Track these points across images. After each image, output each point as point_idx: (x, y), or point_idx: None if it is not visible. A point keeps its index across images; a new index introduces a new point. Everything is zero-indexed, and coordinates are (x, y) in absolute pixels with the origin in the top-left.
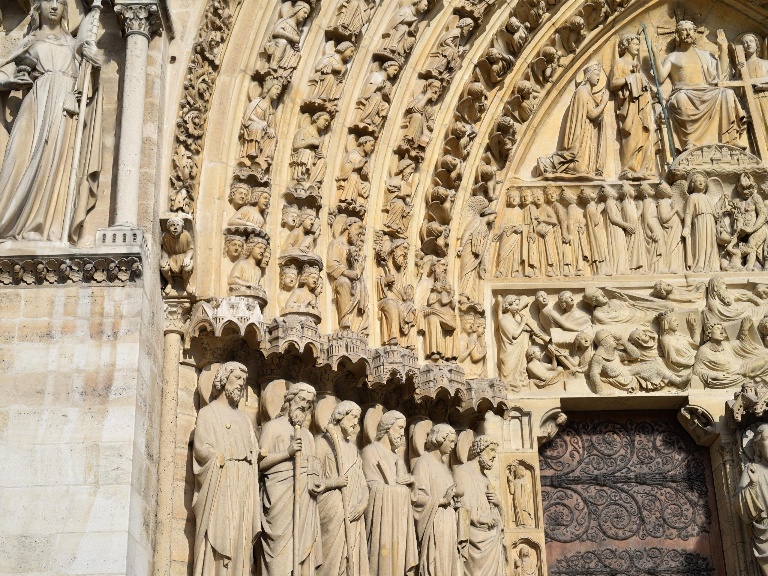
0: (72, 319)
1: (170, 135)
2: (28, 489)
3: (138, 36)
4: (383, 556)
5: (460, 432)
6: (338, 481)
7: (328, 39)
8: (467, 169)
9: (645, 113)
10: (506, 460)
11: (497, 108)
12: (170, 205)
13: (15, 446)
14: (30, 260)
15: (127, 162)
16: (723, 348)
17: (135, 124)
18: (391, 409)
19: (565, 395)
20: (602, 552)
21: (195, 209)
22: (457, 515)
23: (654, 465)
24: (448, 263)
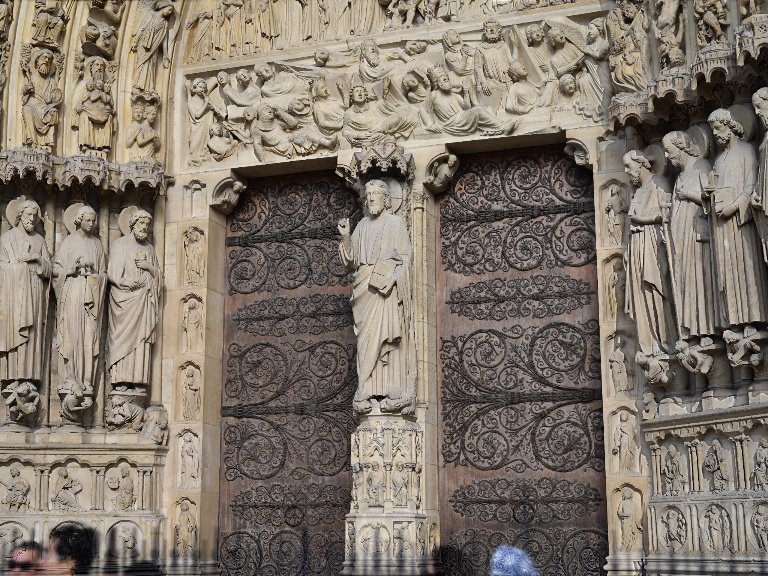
0: None
1: None
2: None
3: None
4: None
5: (123, 209)
6: None
7: None
8: None
9: None
10: (183, 228)
11: None
12: None
13: None
14: None
15: None
16: (366, 109)
17: None
18: (48, 197)
19: (235, 166)
20: (275, 300)
21: None
22: None
23: (326, 220)
24: (122, 59)
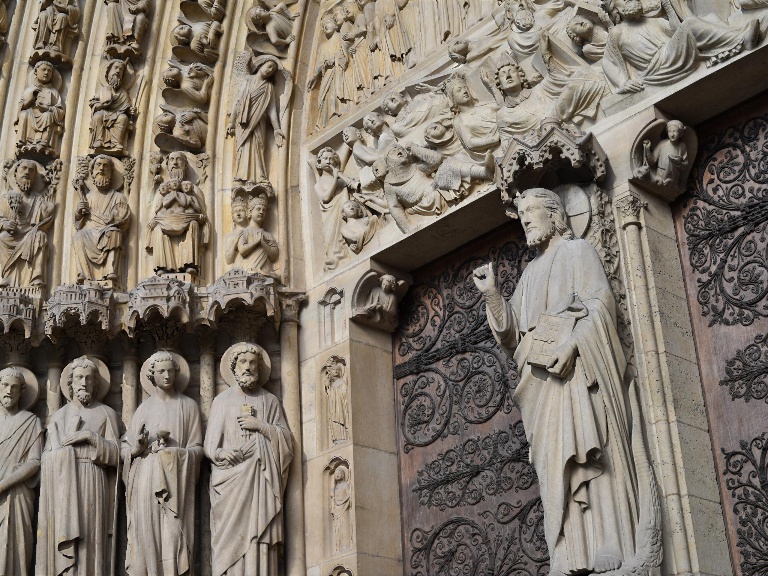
0: None
1: None
2: None
3: None
4: (37, 537)
5: None
6: None
7: None
8: (235, 26)
9: None
10: (321, 362)
11: None
12: None
13: None
14: None
15: None
16: (525, 97)
17: None
18: (125, 353)
19: (375, 251)
20: (464, 446)
21: None
22: None
23: None
24: (218, 149)
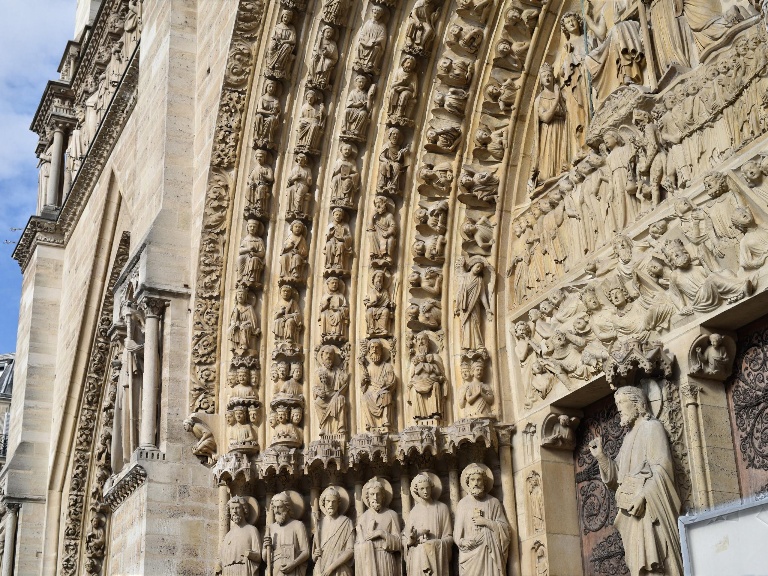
0: None
1: None
2: None
3: None
4: None
5: None
6: (314, 554)
7: None
8: None
9: (578, 90)
10: (526, 474)
11: None
12: None
13: None
14: (121, 483)
15: None
16: (628, 309)
17: (145, 379)
18: (401, 472)
19: (553, 400)
20: (617, 534)
21: (216, 401)
22: None
23: None
24: (450, 326)
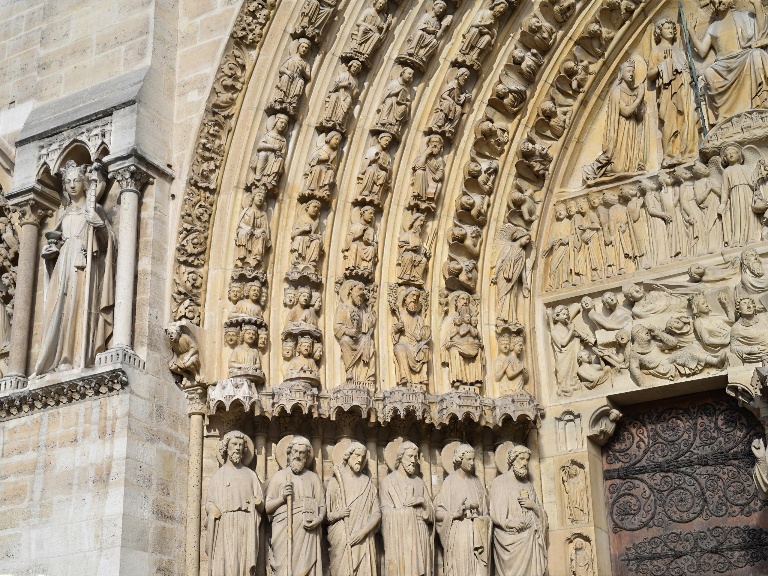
0: (89, 426)
1: (172, 259)
2: (63, 557)
3: (126, 193)
4: (390, 571)
5: (498, 446)
6: (340, 513)
7: (320, 133)
8: (497, 200)
9: (678, 97)
10: (560, 462)
11: (523, 135)
12: (173, 316)
13: (57, 526)
14: (59, 387)
15: (118, 297)
16: (756, 321)
17: (124, 265)
18: (422, 437)
19: (611, 393)
20: (668, 536)
21: (202, 312)
22: (473, 525)
23: (716, 445)
24: (483, 292)
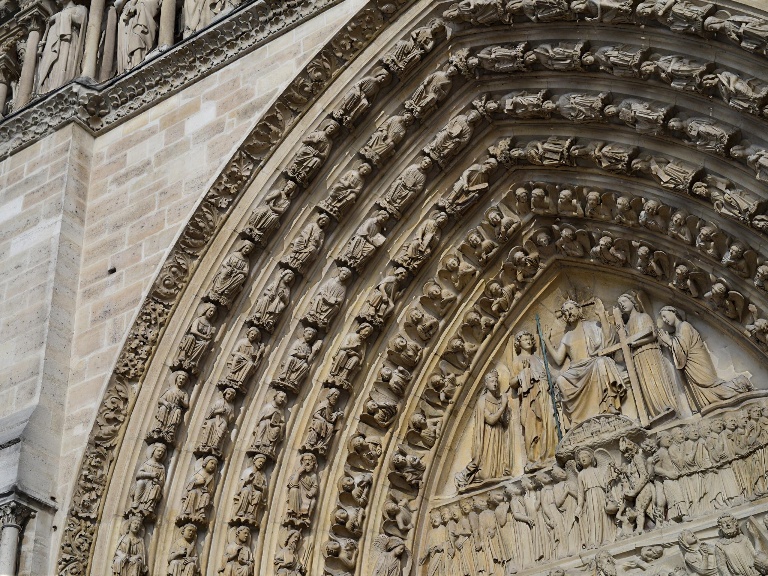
0: None
1: None
2: None
3: (7, 528)
4: None
5: None
6: None
7: (199, 457)
8: (373, 512)
9: (537, 404)
10: None
11: (395, 447)
12: None
13: None
14: None
15: None
16: None
17: None
18: None
19: None
20: None
21: None
22: None
23: None
24: None
